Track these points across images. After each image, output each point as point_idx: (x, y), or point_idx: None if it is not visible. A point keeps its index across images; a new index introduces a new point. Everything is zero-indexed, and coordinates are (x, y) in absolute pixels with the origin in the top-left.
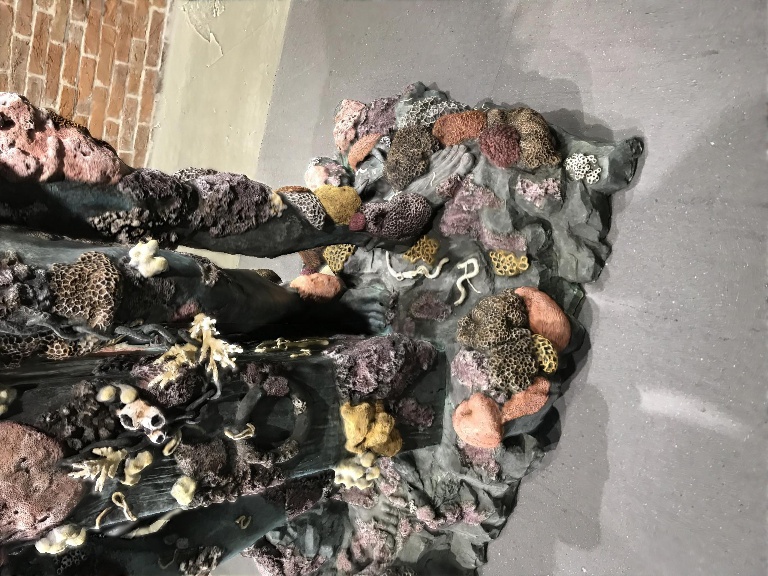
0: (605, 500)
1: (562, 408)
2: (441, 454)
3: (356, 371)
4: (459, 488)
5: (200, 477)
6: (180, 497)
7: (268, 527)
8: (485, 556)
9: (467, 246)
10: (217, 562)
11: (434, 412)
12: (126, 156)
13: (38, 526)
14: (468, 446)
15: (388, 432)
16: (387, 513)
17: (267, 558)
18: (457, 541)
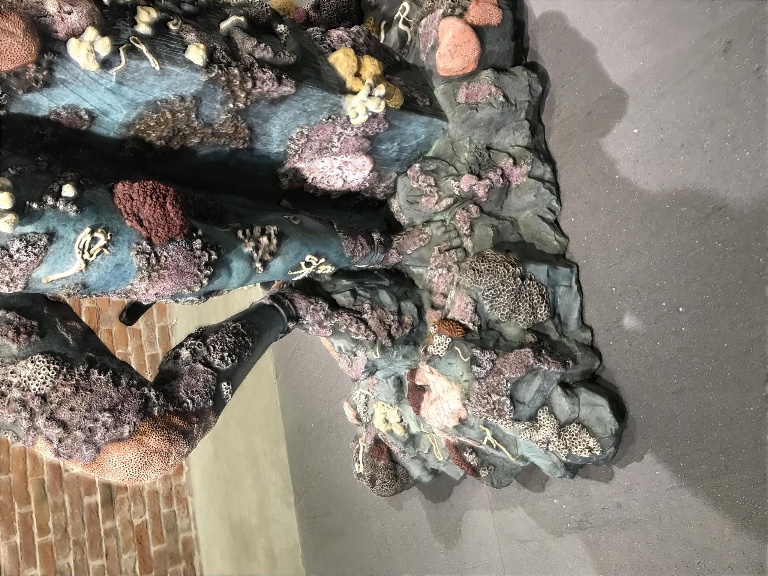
0: (607, 64)
1: (535, 55)
2: (453, 127)
3: (329, 35)
4: (489, 155)
5: (208, 47)
6: (193, 52)
7: (323, 238)
8: (563, 234)
9: (393, 2)
10: (276, 237)
11: (427, 96)
12: (154, 357)
13: (64, 18)
14: (468, 98)
15: (378, 66)
16: (444, 233)
17: (347, 315)
18: (525, 226)
